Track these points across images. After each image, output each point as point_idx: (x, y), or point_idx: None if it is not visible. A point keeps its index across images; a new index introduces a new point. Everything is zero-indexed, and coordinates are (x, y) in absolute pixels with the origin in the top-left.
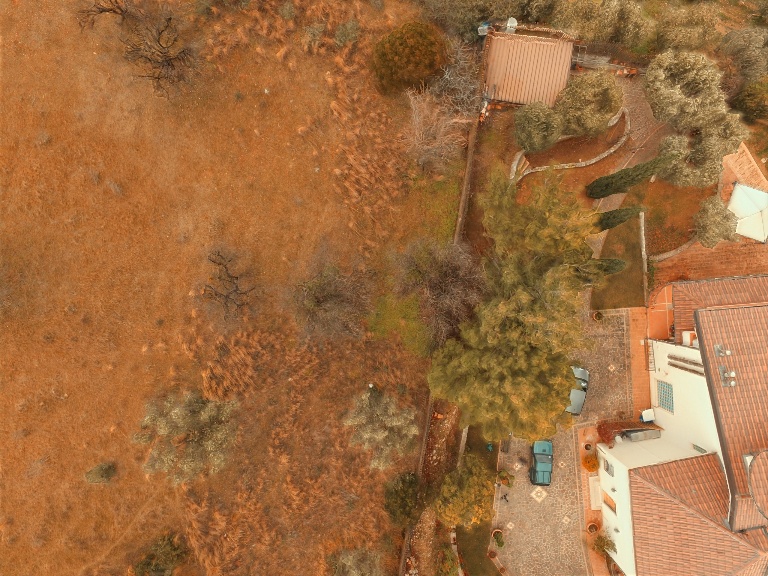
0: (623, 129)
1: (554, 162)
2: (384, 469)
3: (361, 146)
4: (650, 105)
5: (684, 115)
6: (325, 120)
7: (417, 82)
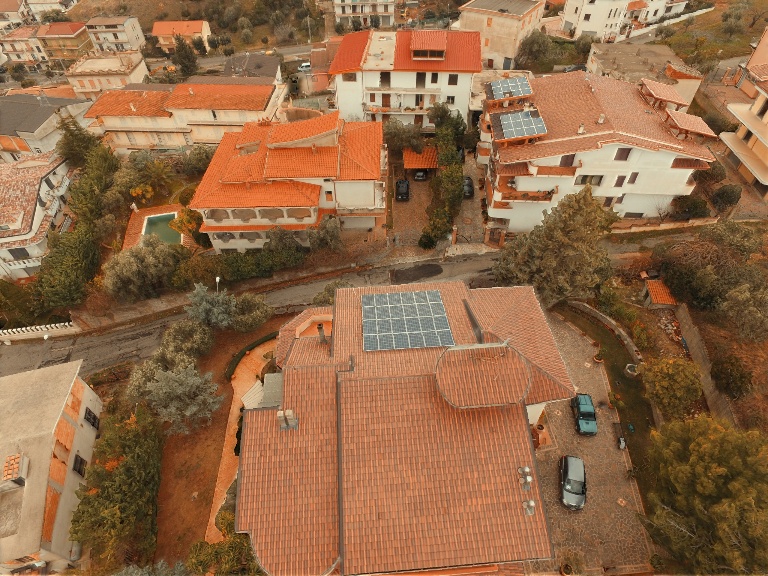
0: None
1: None
2: (759, 403)
3: None
4: None
5: None
6: None
7: None
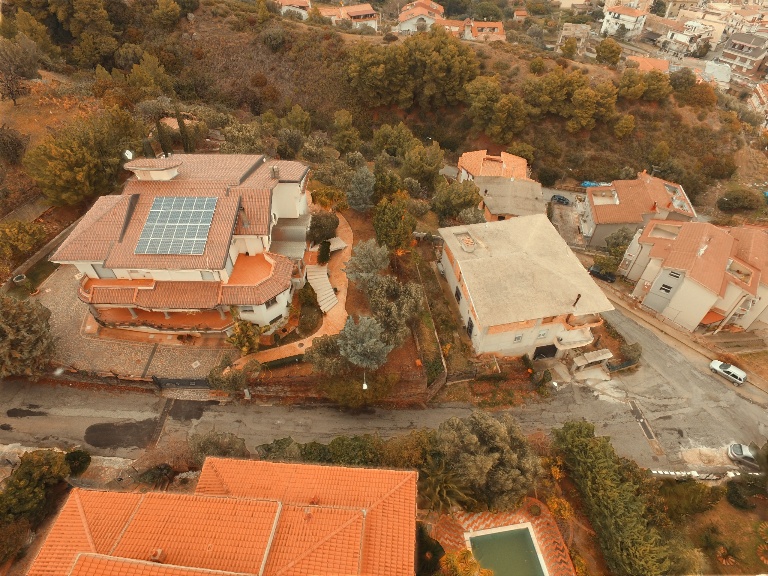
0: None
1: None
2: None
3: None
4: None
5: None
6: None
7: None
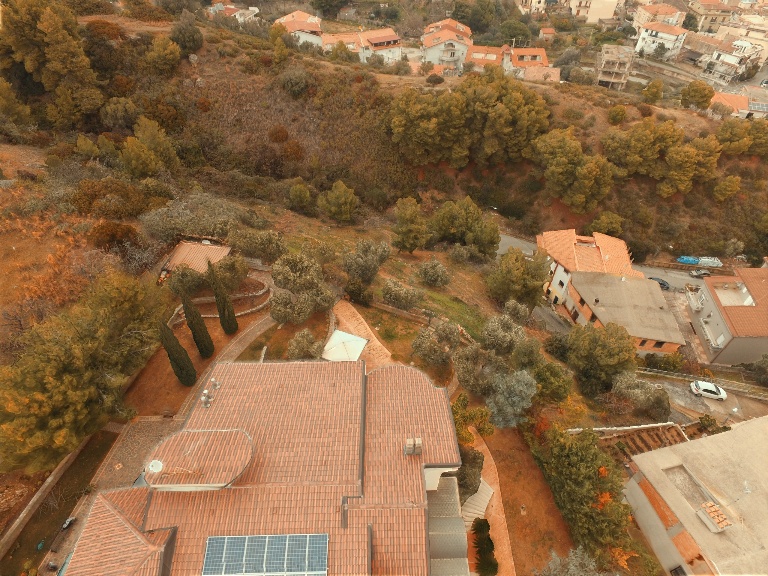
0: (266, 299)
1: (211, 313)
2: None
3: (57, 279)
4: (273, 279)
5: (289, 282)
6: (43, 266)
7: (105, 246)
